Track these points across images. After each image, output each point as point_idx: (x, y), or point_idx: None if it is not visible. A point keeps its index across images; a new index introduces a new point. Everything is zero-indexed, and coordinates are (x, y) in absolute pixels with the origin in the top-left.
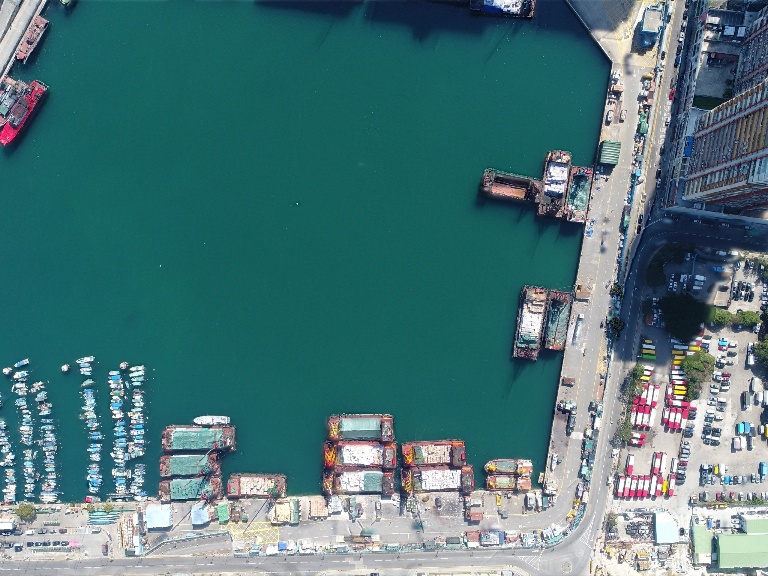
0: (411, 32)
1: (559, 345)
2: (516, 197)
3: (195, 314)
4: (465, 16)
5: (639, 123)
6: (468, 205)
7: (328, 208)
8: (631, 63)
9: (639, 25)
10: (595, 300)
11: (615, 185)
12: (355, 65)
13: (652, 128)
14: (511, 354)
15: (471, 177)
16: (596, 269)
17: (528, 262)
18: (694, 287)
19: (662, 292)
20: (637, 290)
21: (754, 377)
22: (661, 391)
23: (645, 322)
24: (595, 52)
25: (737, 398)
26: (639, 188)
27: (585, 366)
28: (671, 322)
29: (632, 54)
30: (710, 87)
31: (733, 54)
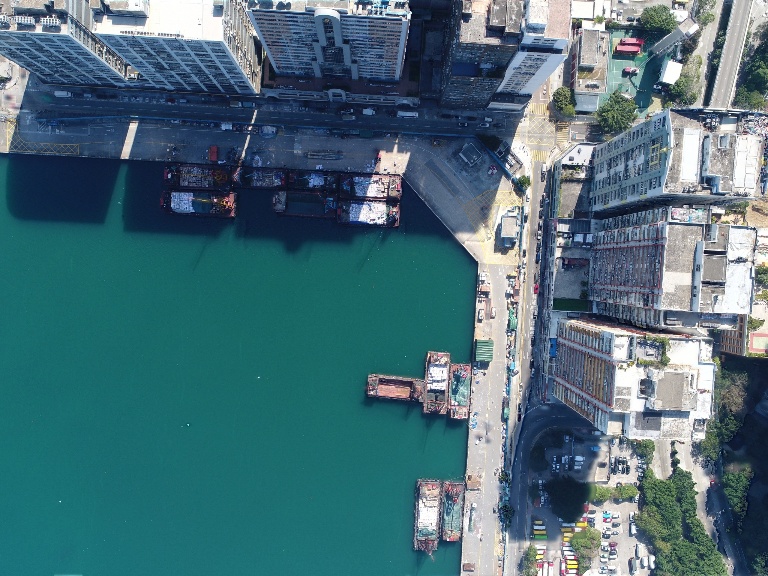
0: (284, 247)
1: (456, 536)
2: (401, 399)
3: (96, 542)
4: (334, 228)
5: (509, 319)
6: (357, 407)
7: (220, 424)
8: (496, 262)
9: (499, 227)
10: (486, 488)
11: (493, 378)
12: (232, 284)
13: (521, 322)
14: (412, 546)
15: (356, 382)
16: (484, 458)
17: (420, 456)
18: (575, 467)
19: (547, 474)
20: (524, 474)
21: (638, 544)
22: (556, 566)
23: (534, 504)
24: (461, 253)
25: (625, 564)
26: (515, 379)
27: (483, 550)
28: (556, 508)
29: (496, 254)
30: (567, 289)
31: (585, 258)
